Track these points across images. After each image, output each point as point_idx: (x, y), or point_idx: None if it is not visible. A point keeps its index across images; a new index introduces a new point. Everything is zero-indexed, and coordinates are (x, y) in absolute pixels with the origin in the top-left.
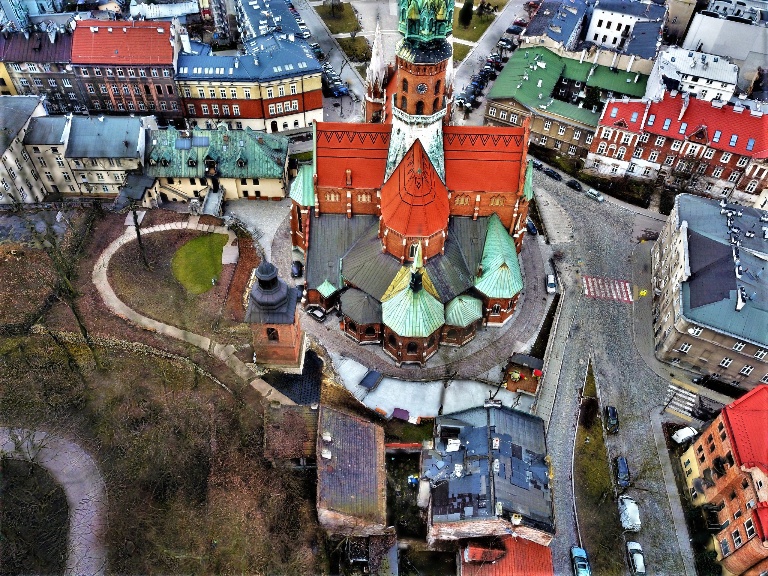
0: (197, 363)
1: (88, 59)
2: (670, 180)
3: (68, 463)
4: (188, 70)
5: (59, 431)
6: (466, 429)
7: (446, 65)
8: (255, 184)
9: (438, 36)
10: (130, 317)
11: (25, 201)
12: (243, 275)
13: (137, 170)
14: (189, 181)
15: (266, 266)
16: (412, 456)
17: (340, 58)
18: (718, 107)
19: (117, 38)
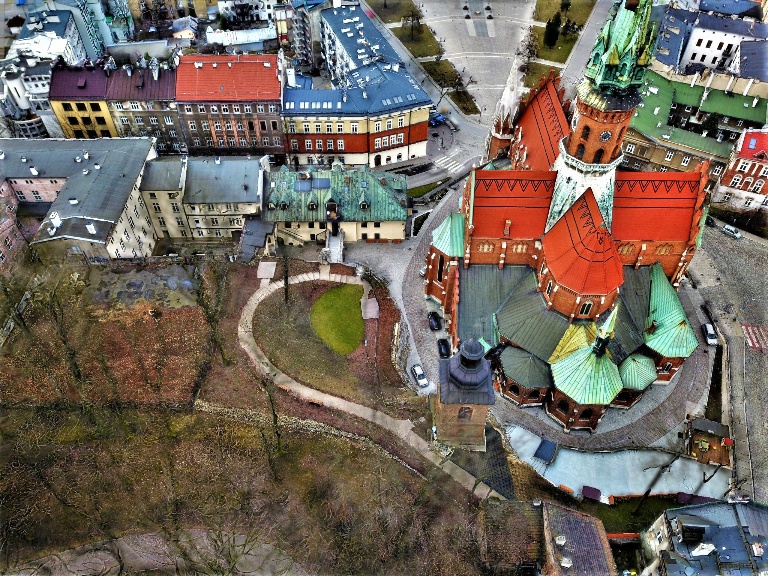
0: (379, 443)
1: (193, 96)
2: None
3: (278, 573)
4: (294, 105)
5: (259, 533)
6: (712, 529)
7: None
8: (376, 226)
9: (634, 82)
10: (291, 387)
11: (141, 250)
12: (387, 331)
13: (255, 215)
14: (307, 225)
15: (476, 345)
16: (623, 547)
17: (428, 84)
18: None
19: (222, 73)
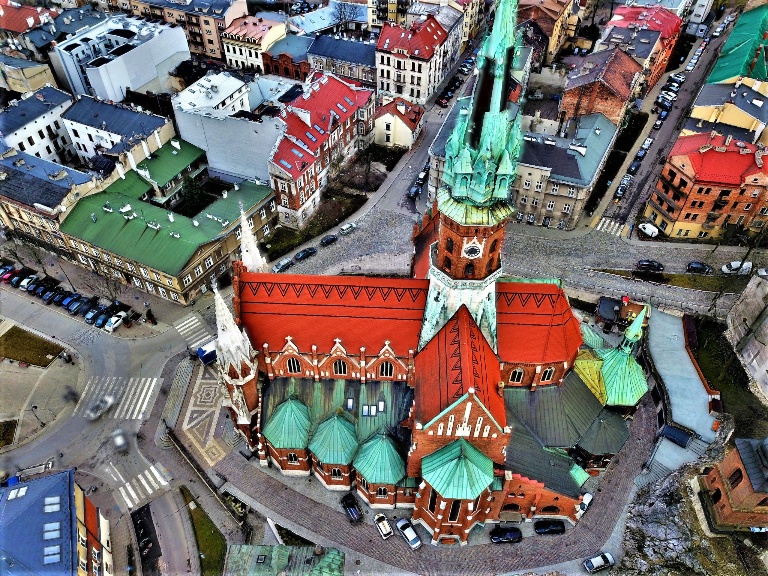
0: None
1: None
2: None
3: None
4: None
5: None
6: None
7: None
8: None
9: None
10: None
11: None
12: None
13: None
14: None
15: None
16: None
17: None
18: (308, 97)
19: None
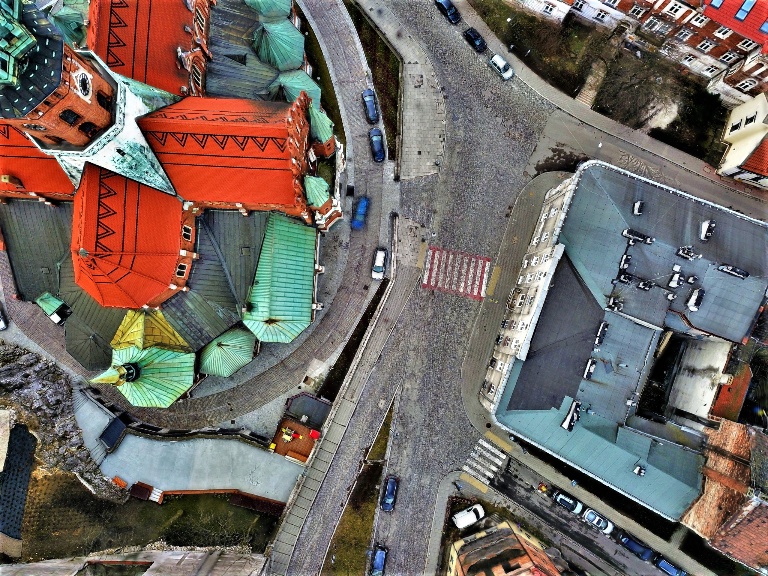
0: None
1: None
2: (633, 36)
3: None
4: None
5: None
6: None
7: (61, 91)
8: None
9: None
10: None
11: None
12: None
13: None
14: None
15: None
16: None
17: None
18: None
19: None
